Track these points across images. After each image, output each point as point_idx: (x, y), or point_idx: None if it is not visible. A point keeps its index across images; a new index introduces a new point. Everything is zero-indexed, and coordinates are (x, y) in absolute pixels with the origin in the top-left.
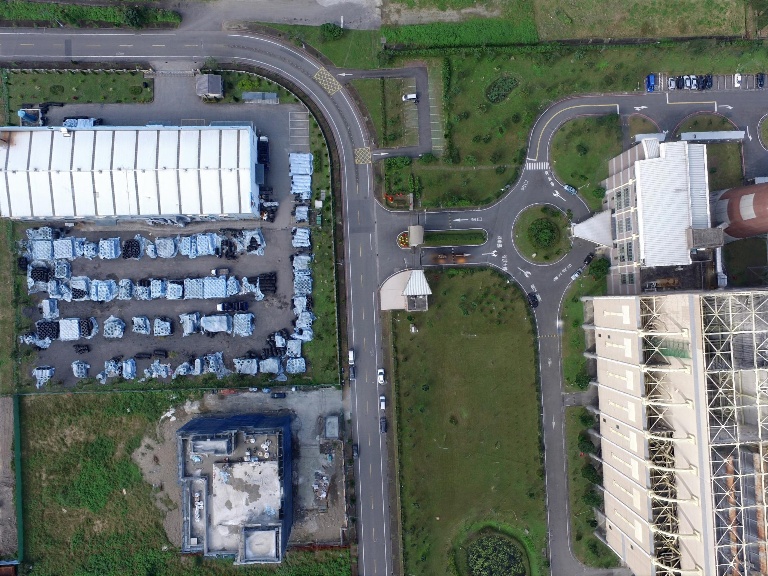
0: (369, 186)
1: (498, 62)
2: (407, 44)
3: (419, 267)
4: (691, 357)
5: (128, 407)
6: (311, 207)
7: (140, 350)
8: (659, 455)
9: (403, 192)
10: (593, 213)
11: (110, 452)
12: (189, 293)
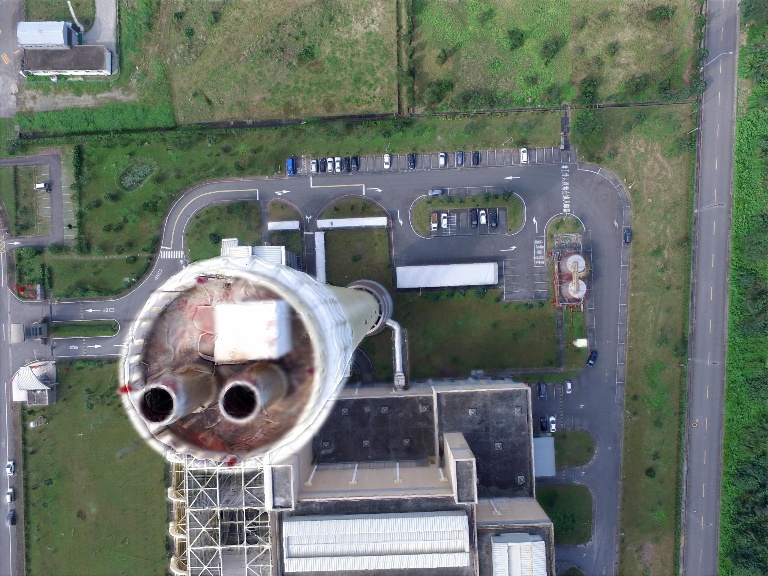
0: (3, 276)
1: (131, 148)
2: (42, 131)
3: (51, 358)
4: None
5: None
6: None
7: None
8: None
9: (33, 283)
10: None
11: None
12: None
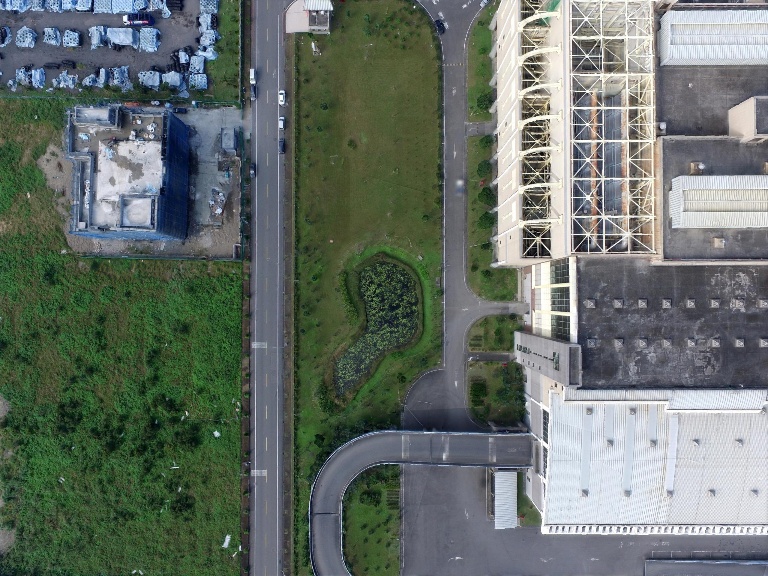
0: None
1: None
2: None
3: None
4: None
5: (36, 114)
6: None
7: (50, 60)
8: (539, 133)
9: None
10: None
11: (17, 157)
12: (98, 6)
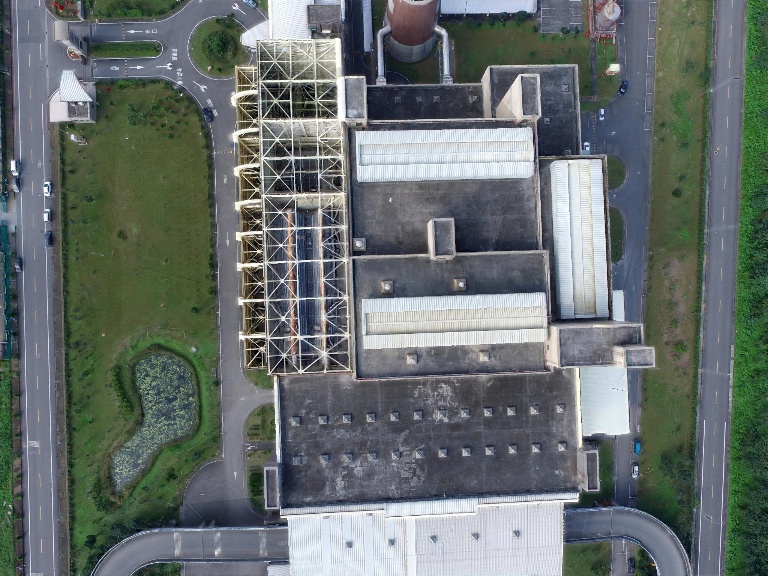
0: None
1: None
2: None
3: (90, 79)
4: None
5: None
6: None
7: None
8: None
9: (72, 0)
10: None
11: None
12: None
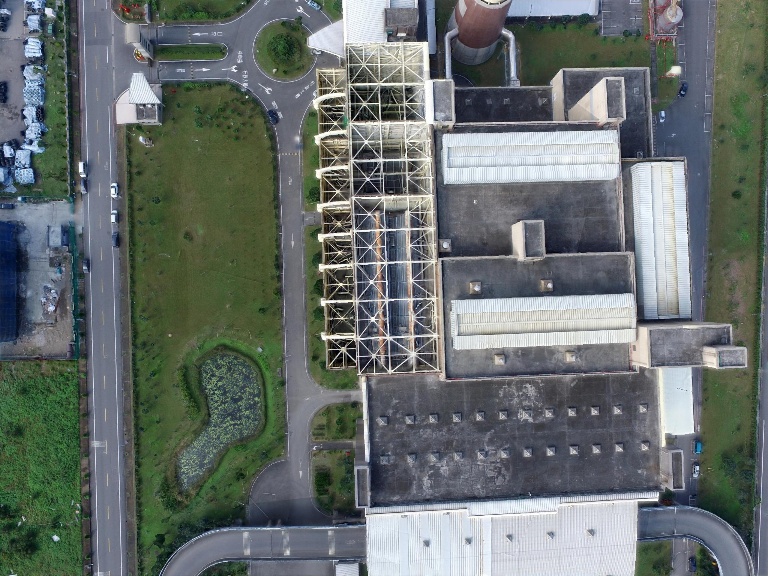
0: None
1: None
2: None
3: (156, 81)
4: None
5: None
6: (45, 17)
7: None
8: (348, 240)
9: (139, 3)
10: None
11: None
12: None
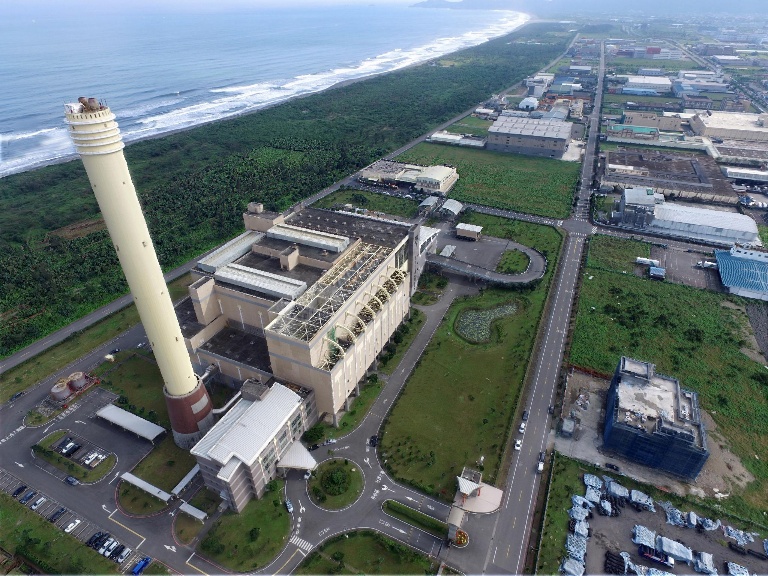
0: None
1: None
2: None
3: None
4: (332, 327)
5: (766, 517)
6: None
7: (762, 563)
8: None
9: None
10: (285, 479)
11: None
12: None
